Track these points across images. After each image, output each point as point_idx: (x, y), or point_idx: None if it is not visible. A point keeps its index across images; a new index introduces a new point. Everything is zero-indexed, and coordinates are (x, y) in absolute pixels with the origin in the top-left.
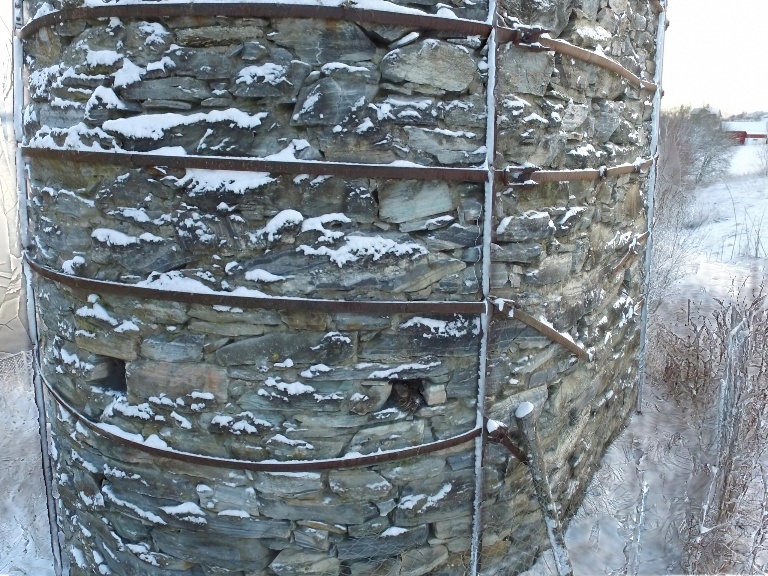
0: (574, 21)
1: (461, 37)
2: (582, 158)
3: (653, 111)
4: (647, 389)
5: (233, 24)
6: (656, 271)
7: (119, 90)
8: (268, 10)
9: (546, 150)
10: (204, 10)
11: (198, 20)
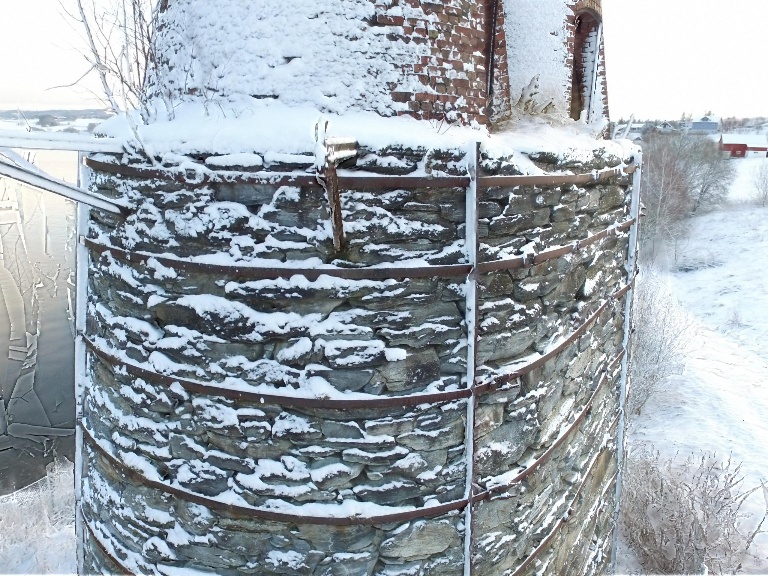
0: (539, 433)
1: (443, 513)
2: (547, 527)
3: (622, 370)
4: (624, 552)
5: (264, 522)
6: (643, 375)
7: (171, 545)
8: (292, 519)
9: (514, 556)
10: (241, 511)
11: (236, 515)
